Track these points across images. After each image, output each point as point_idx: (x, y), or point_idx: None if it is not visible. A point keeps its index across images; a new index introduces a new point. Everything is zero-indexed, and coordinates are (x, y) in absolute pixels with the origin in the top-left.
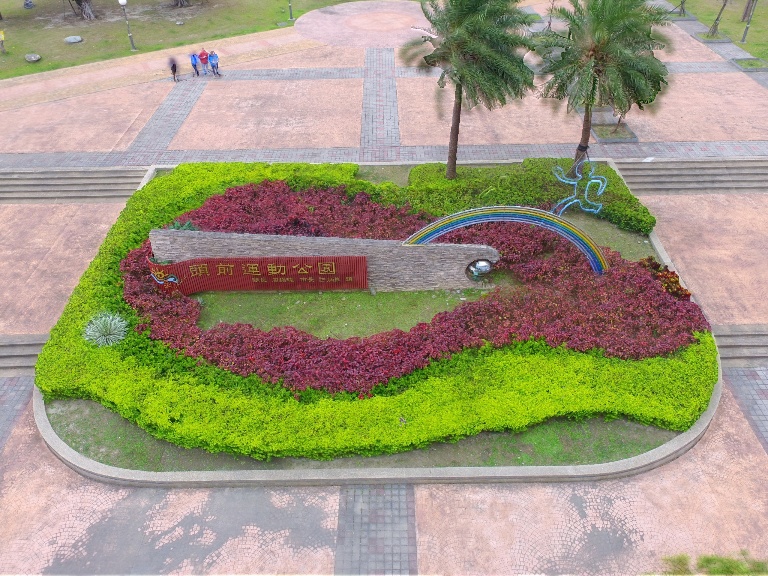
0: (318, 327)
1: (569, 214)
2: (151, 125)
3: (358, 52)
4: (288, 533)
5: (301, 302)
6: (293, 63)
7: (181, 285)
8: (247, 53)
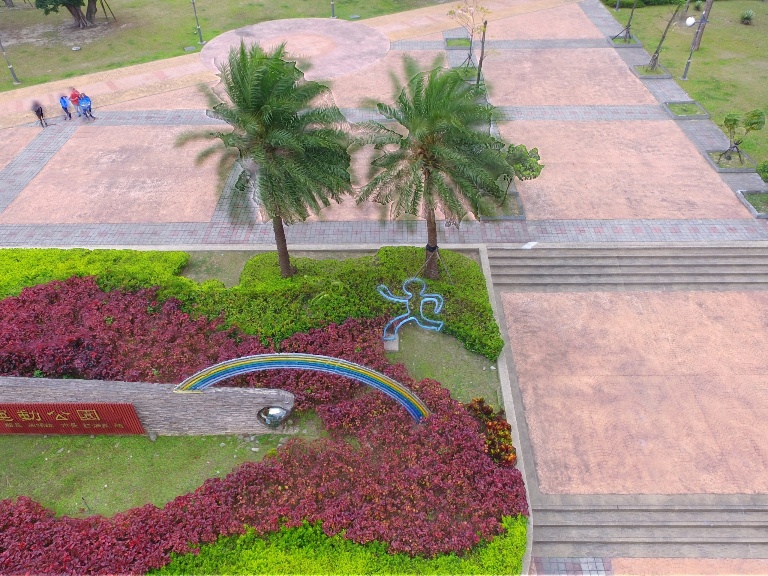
0: (70, 490)
1: (414, 325)
2: None
3: None
4: None
5: (65, 450)
6: (180, 102)
7: None
8: (136, 88)
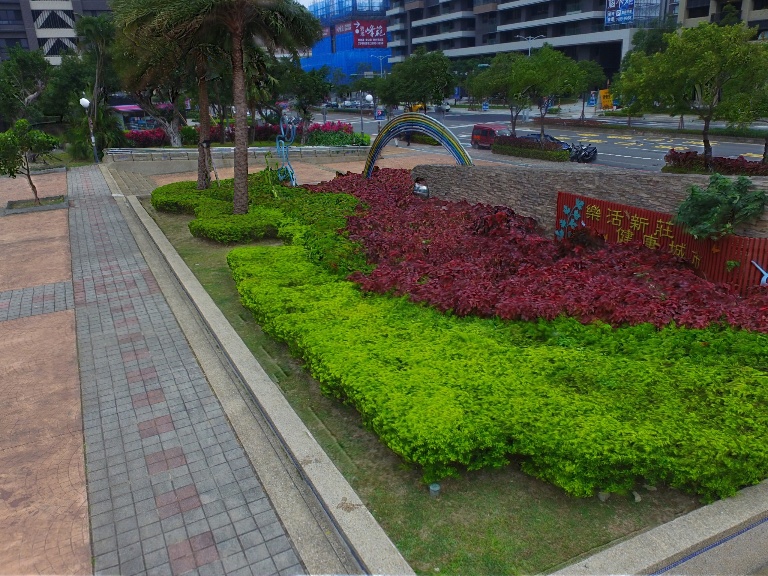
0: None
1: None
2: None
3: None
4: None
5: None
6: None
7: None
8: None
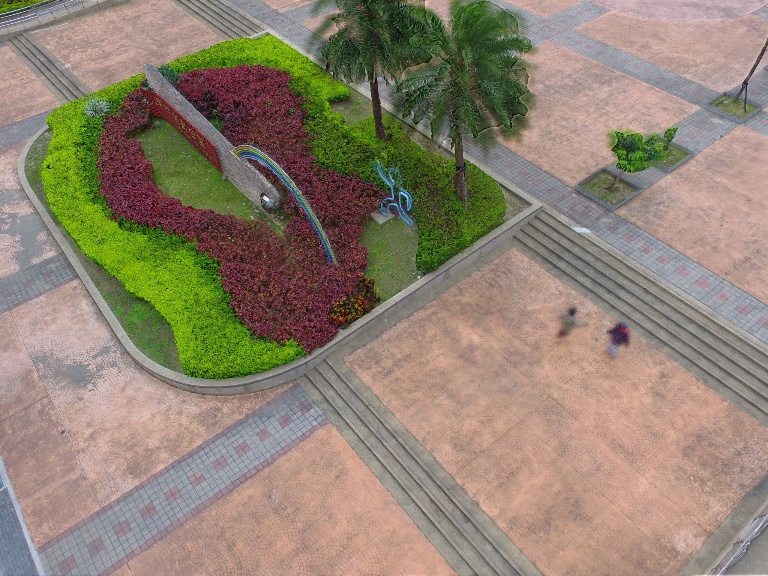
0: (172, 175)
1: (412, 218)
2: (324, 1)
3: (570, 1)
4: (22, 250)
5: (191, 157)
6: None
7: (152, 107)
8: None
